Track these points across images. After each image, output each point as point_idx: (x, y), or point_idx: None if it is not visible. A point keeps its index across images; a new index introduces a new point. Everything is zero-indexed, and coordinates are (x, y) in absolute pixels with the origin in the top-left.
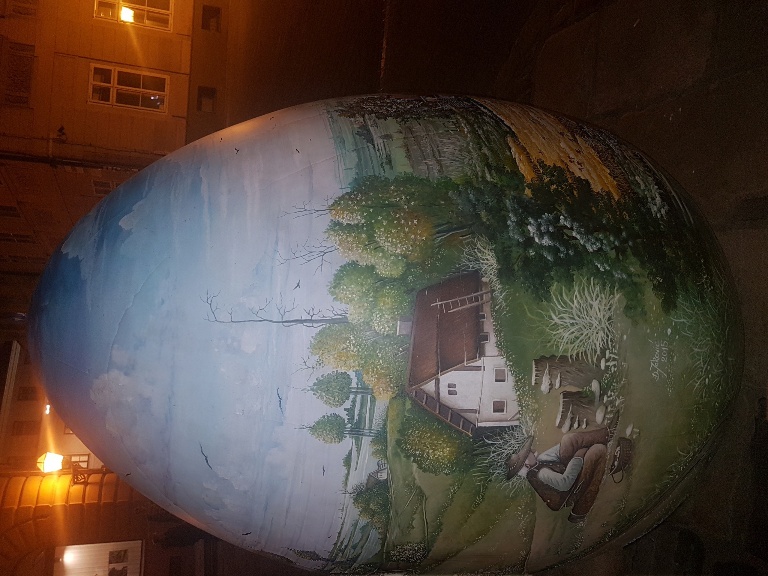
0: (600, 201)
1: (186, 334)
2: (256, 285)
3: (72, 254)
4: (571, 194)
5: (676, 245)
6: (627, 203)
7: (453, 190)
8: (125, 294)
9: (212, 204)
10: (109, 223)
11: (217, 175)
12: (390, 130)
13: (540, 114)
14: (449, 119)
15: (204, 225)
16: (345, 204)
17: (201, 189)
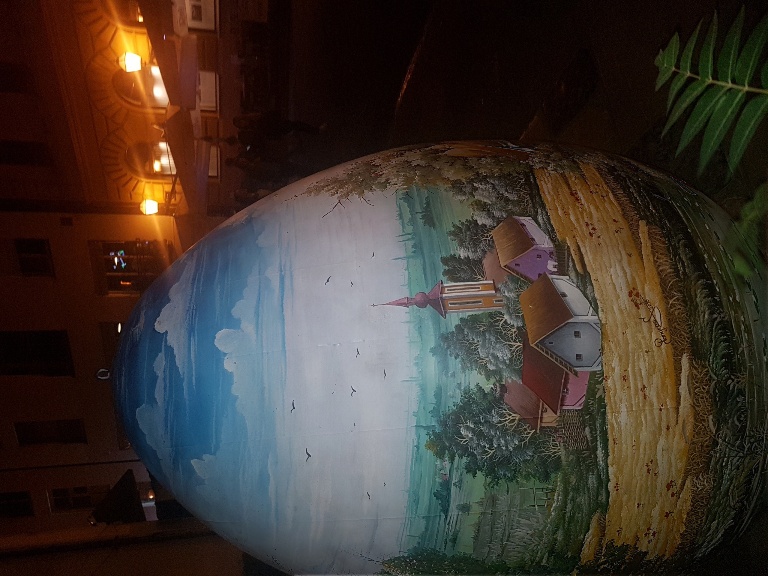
0: (644, 567)
1: (256, 555)
2: (312, 572)
3: (149, 441)
4: (617, 569)
5: (696, 567)
6: (673, 559)
7: (502, 571)
8: (205, 515)
9: (279, 511)
10: (181, 449)
11: (285, 480)
12: (471, 498)
13: (675, 433)
14: (545, 484)
15: (271, 525)
16: (398, 563)
17: (269, 491)
